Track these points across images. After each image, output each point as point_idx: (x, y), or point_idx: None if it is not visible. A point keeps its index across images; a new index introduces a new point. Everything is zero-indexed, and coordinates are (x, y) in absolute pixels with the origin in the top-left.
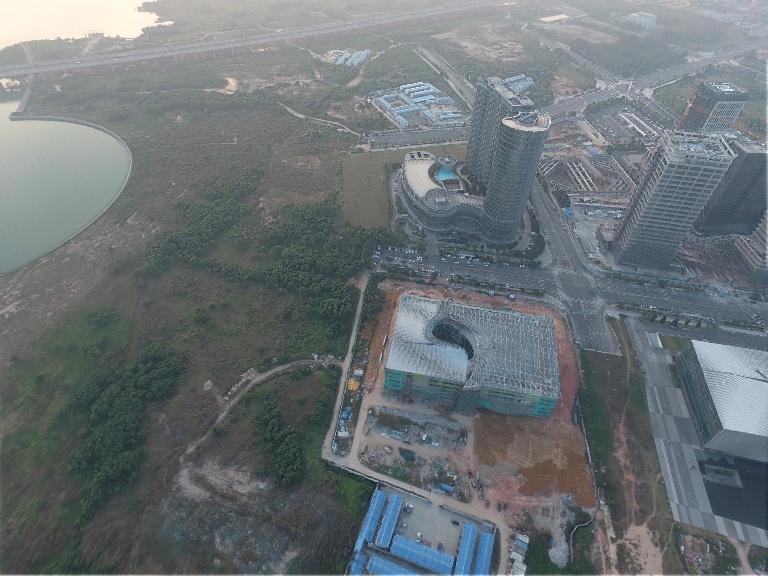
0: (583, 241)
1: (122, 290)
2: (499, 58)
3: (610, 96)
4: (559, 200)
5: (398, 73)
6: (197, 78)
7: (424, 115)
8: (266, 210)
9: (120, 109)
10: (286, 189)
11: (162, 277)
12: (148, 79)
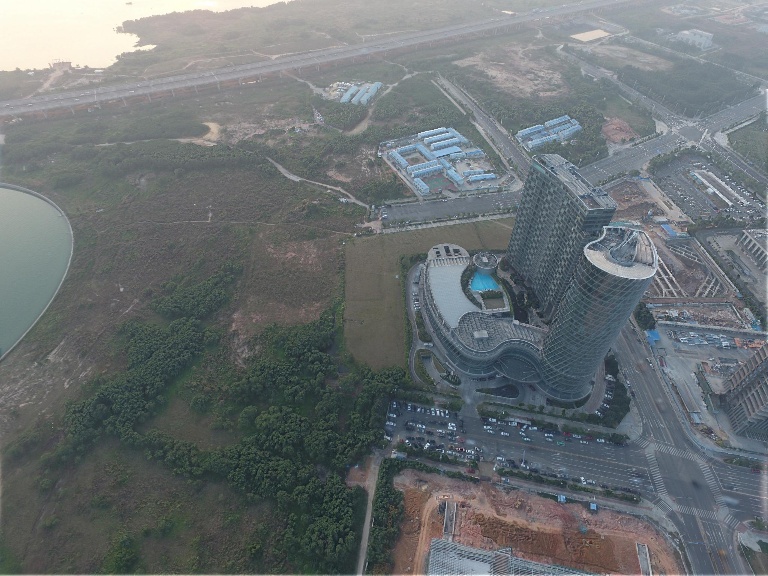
0: (680, 389)
1: (18, 494)
2: (535, 92)
3: (676, 144)
4: (637, 316)
5: (415, 114)
6: (171, 124)
7: (449, 176)
8: (240, 335)
9: (71, 170)
10: (269, 298)
11: (80, 467)
12: (113, 125)
